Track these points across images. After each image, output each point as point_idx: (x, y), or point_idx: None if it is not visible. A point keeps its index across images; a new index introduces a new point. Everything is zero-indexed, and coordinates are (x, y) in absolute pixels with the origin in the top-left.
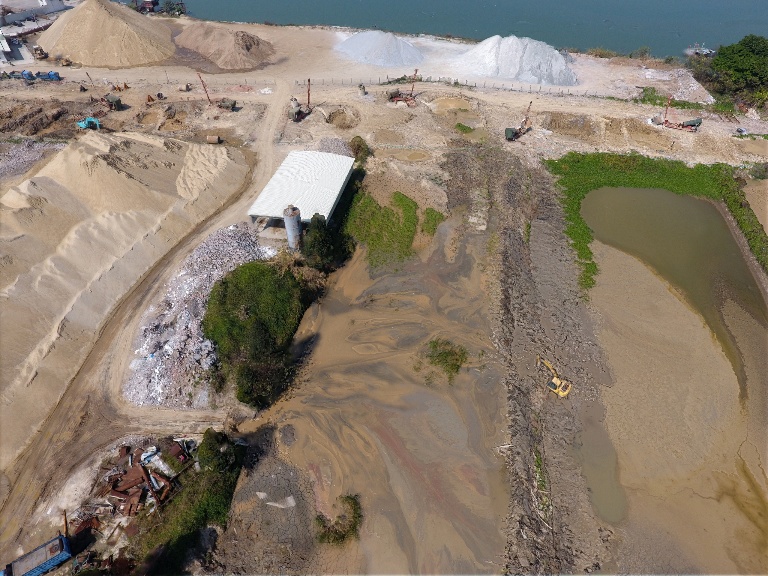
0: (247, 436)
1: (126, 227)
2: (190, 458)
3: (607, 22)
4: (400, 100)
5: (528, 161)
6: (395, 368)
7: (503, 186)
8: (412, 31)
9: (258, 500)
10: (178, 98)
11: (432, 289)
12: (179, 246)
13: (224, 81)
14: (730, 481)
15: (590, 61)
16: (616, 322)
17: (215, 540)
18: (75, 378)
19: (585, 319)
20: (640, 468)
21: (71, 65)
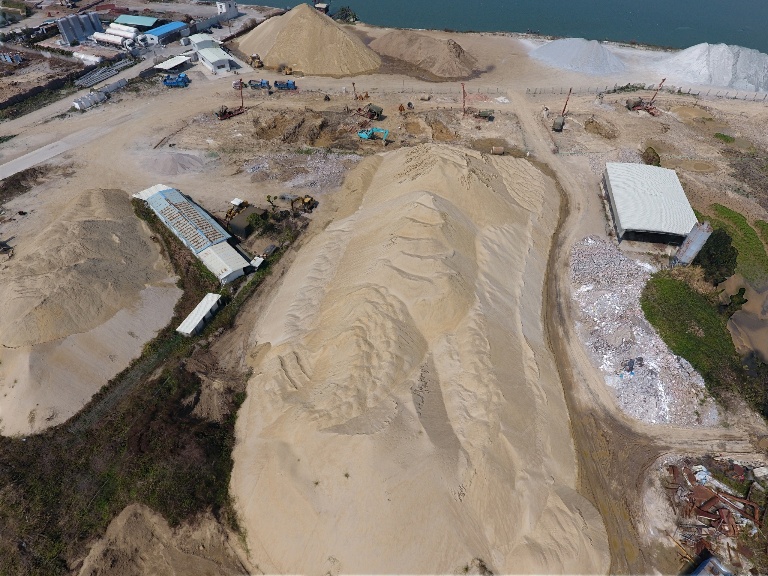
0: None
1: (512, 241)
2: None
3: None
4: (640, 109)
5: None
6: None
7: None
8: (594, 38)
9: None
10: (425, 107)
11: None
12: (552, 260)
13: (454, 90)
14: None
15: None
16: None
17: None
18: (565, 395)
19: None
20: None
21: (293, 74)
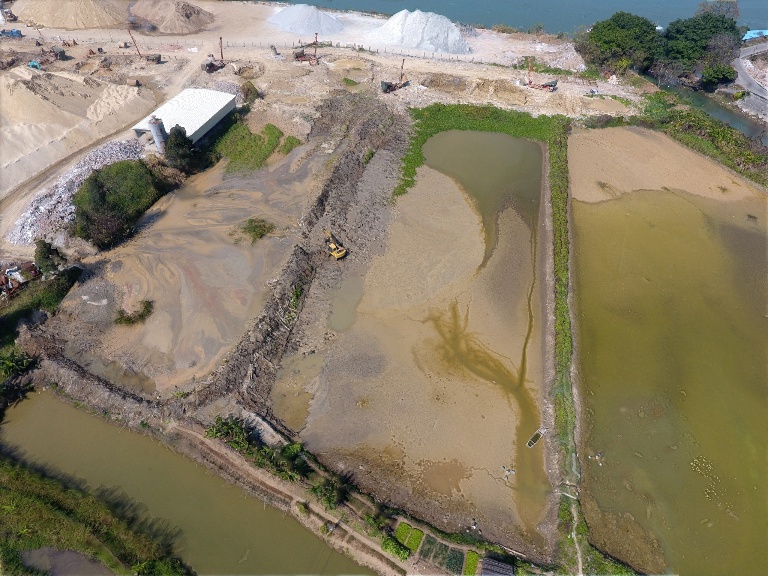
0: (86, 264)
1: (36, 134)
2: (40, 274)
3: (526, 5)
4: (305, 60)
5: (395, 108)
6: (214, 234)
7: (360, 123)
8: (342, 7)
9: (82, 300)
10: (116, 53)
11: (268, 188)
12: (79, 153)
13: (160, 42)
14: (439, 313)
15: (493, 36)
16: (409, 217)
17: (45, 320)
18: None
19: (386, 215)
20: (376, 302)
21: (34, 26)
